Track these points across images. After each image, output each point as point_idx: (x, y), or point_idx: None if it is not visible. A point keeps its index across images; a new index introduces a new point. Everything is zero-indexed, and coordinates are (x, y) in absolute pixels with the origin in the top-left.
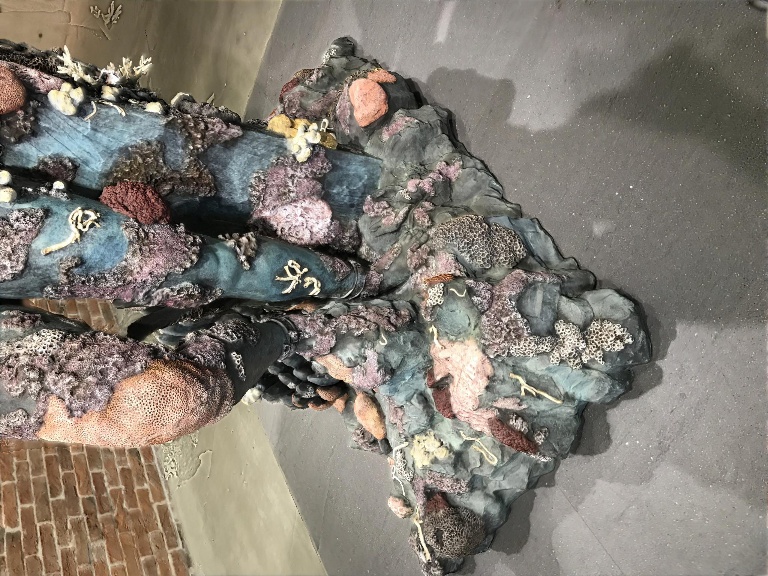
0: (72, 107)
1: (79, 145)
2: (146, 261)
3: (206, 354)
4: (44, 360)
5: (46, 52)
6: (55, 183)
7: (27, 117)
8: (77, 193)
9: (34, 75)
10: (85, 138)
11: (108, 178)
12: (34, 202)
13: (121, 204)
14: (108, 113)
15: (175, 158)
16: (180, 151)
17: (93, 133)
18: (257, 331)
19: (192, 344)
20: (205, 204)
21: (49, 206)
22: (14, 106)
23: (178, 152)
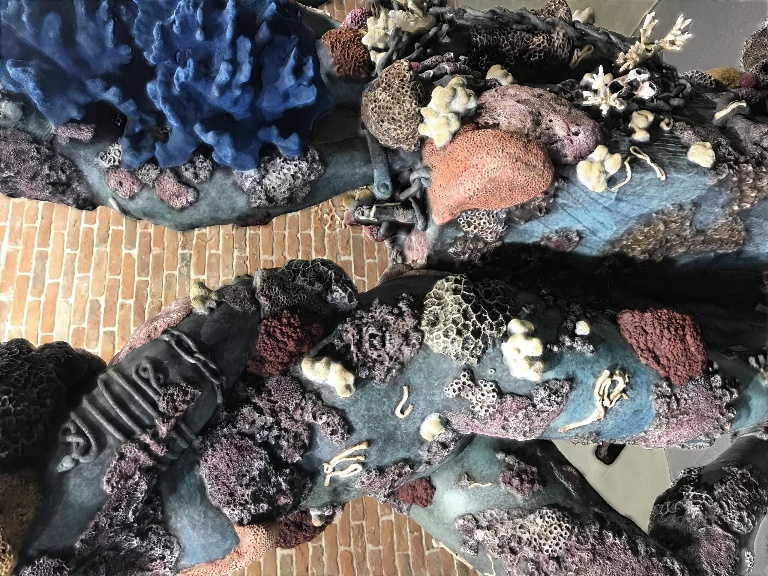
0: (604, 185)
1: (594, 216)
2: (668, 431)
3: (722, 571)
4: (551, 567)
5: (553, 21)
6: (580, 327)
7: (546, 198)
8: (593, 315)
9: (563, 134)
10: (604, 209)
11: (614, 246)
12: (559, 367)
13: (651, 352)
14: (643, 178)
15: (706, 216)
16: (717, 210)
17: (616, 203)
18: (767, 488)
19: (703, 542)
20: (719, 258)
21: (574, 372)
22: (537, 194)
23: (714, 210)
